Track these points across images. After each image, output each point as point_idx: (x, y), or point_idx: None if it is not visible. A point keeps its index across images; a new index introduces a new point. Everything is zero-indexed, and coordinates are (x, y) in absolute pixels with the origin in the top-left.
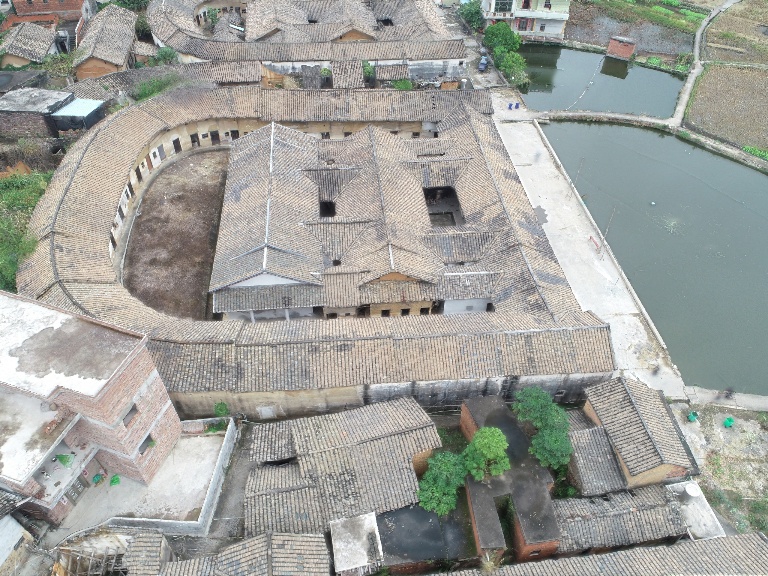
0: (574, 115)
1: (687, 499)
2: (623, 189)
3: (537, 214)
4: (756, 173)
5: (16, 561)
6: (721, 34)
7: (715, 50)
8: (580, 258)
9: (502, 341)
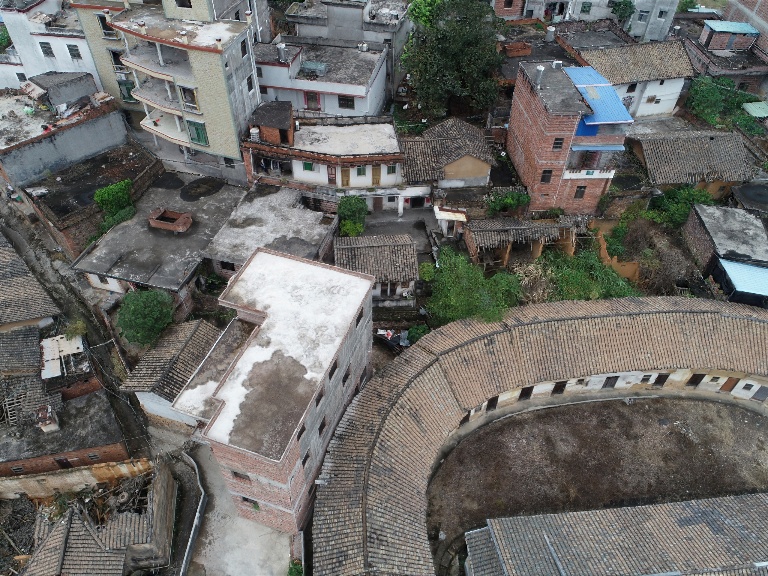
0: None
1: None
2: None
3: None
4: None
5: (184, 429)
6: None
7: None
8: None
9: None
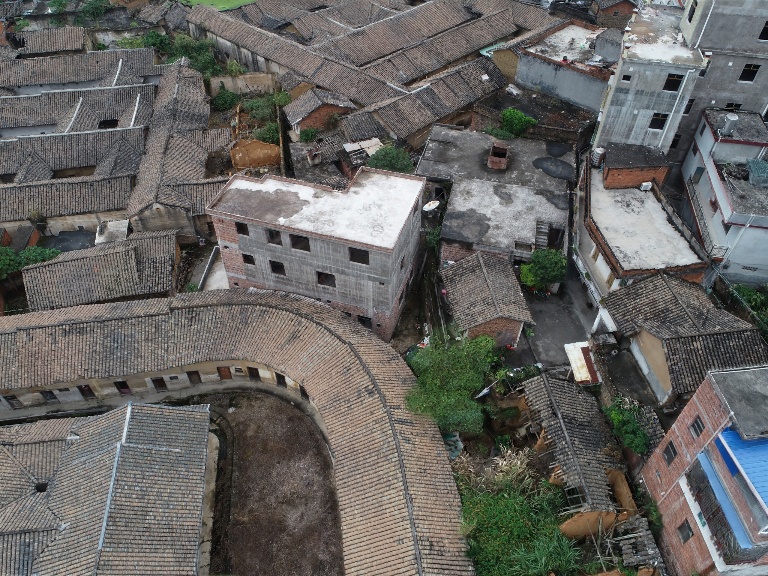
0: None
1: None
2: None
3: None
4: None
5: None
6: None
7: None
8: None
9: None
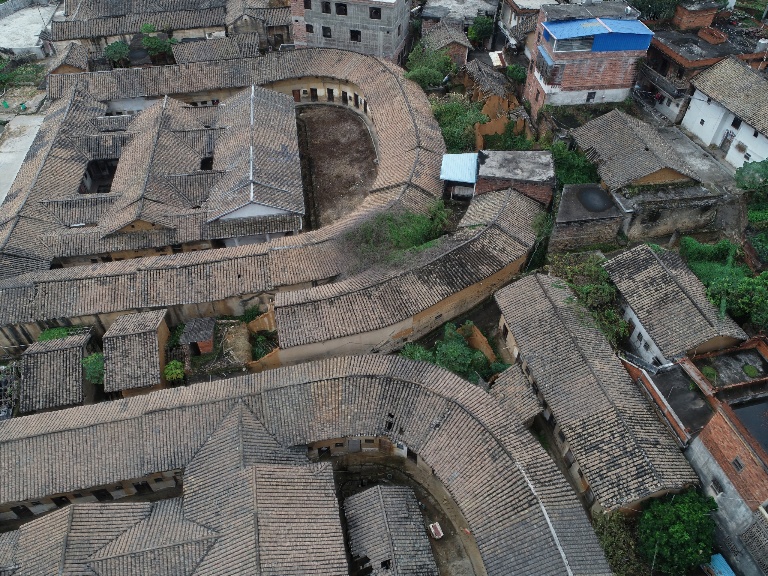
0: None
1: None
2: None
3: None
4: None
5: None
6: None
7: None
8: None
9: None
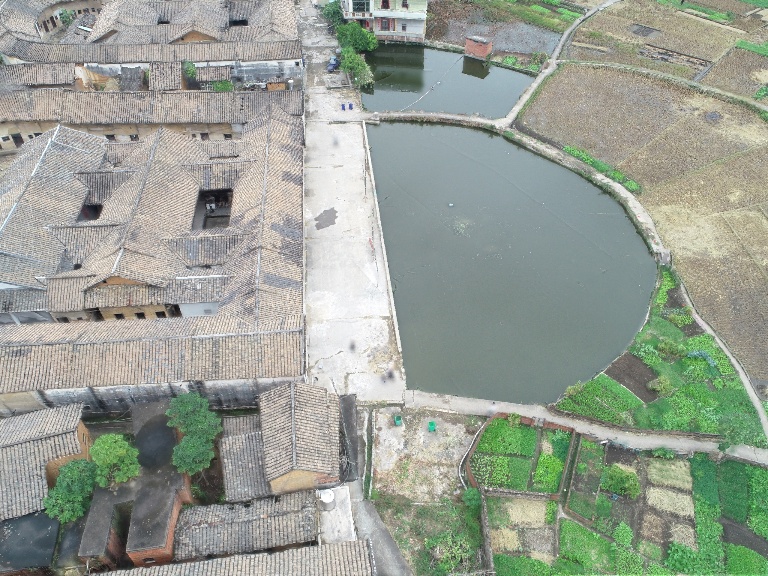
0: (405, 116)
1: (324, 505)
2: (426, 190)
3: (327, 216)
4: (569, 173)
5: None
6: (588, 33)
7: (577, 49)
8: (352, 260)
9: (187, 346)
